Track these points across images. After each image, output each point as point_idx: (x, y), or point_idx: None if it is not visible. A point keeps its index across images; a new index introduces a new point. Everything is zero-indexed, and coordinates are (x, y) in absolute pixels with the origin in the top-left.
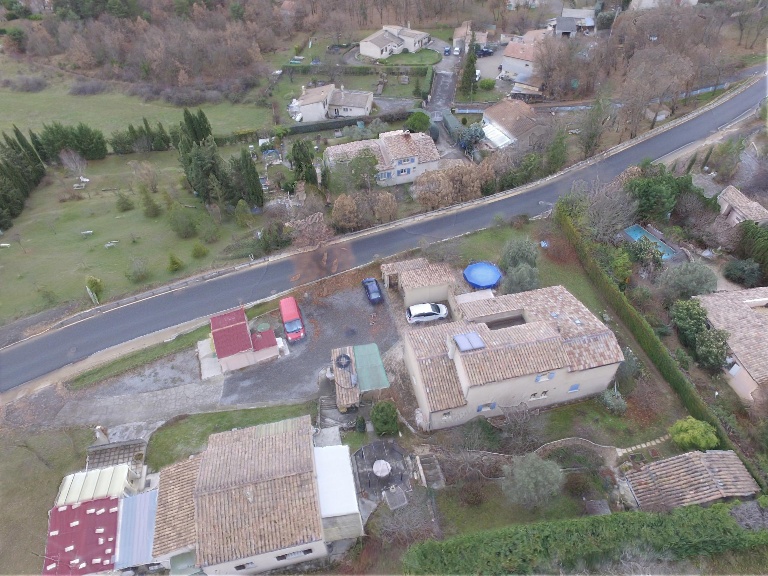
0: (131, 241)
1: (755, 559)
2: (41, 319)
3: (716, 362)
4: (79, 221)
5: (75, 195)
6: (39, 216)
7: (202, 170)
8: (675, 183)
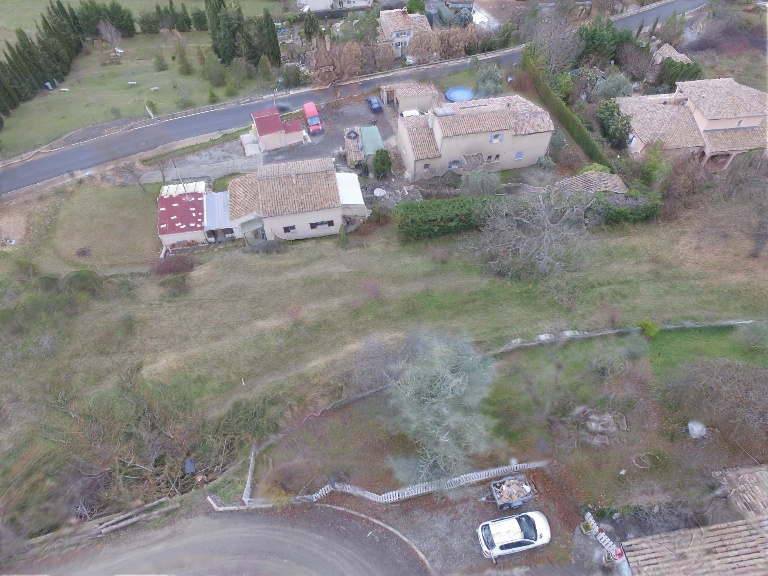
0: (172, 87)
1: (620, 229)
2: (114, 125)
3: (621, 136)
4: (122, 78)
5: (113, 61)
6: (86, 74)
7: (229, 30)
8: (618, 33)
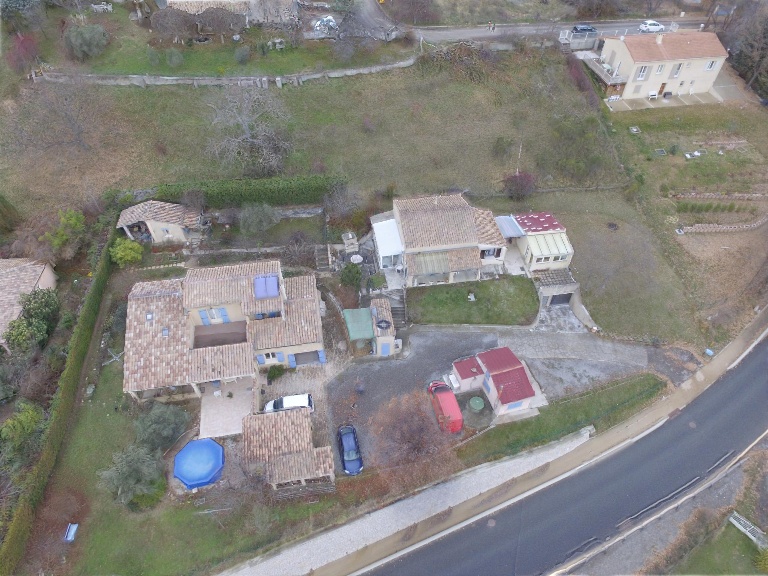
0: None
1: None
2: None
3: None
4: None
5: None
6: None
7: None
8: None
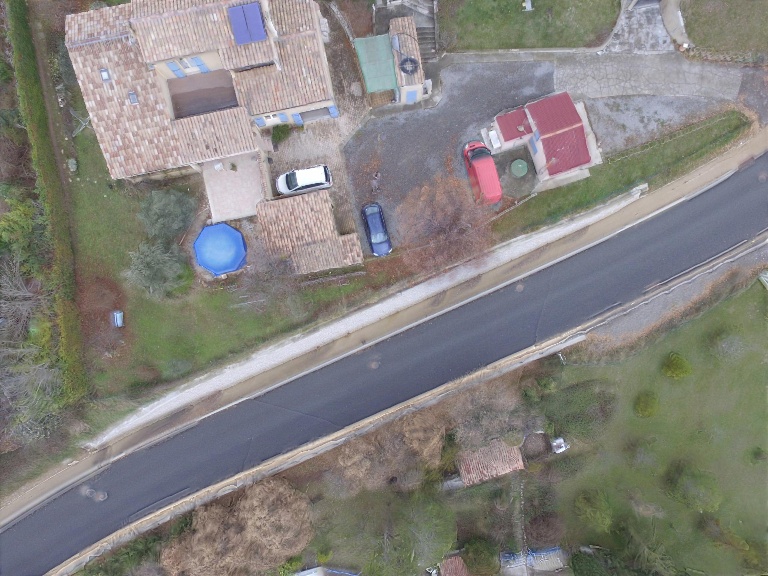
0: (764, 450)
1: None
2: None
3: None
4: None
5: None
6: None
7: None
8: None
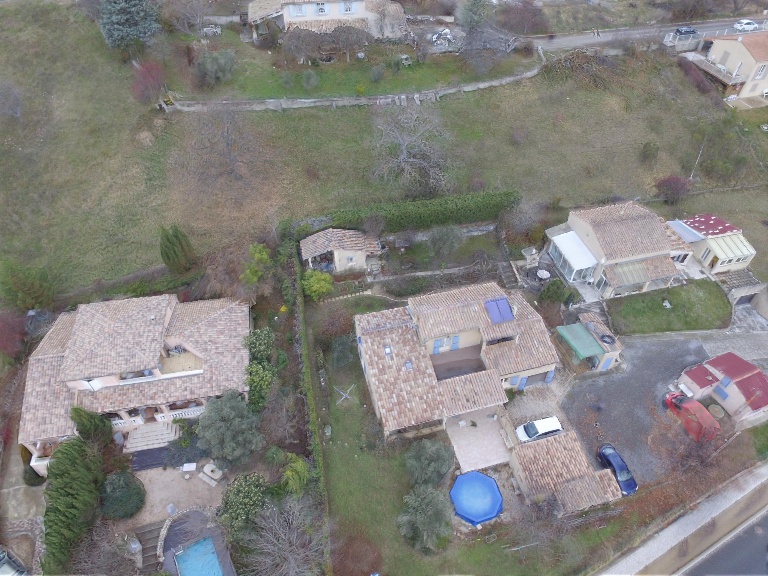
0: None
1: None
2: None
3: None
4: None
5: None
6: None
7: None
8: None
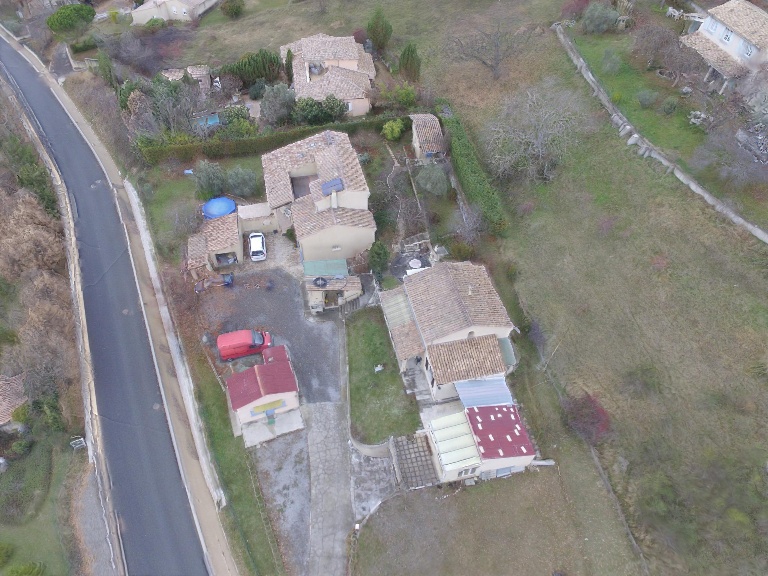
0: None
1: None
2: None
3: None
4: None
5: None
6: None
7: None
8: (165, 81)
